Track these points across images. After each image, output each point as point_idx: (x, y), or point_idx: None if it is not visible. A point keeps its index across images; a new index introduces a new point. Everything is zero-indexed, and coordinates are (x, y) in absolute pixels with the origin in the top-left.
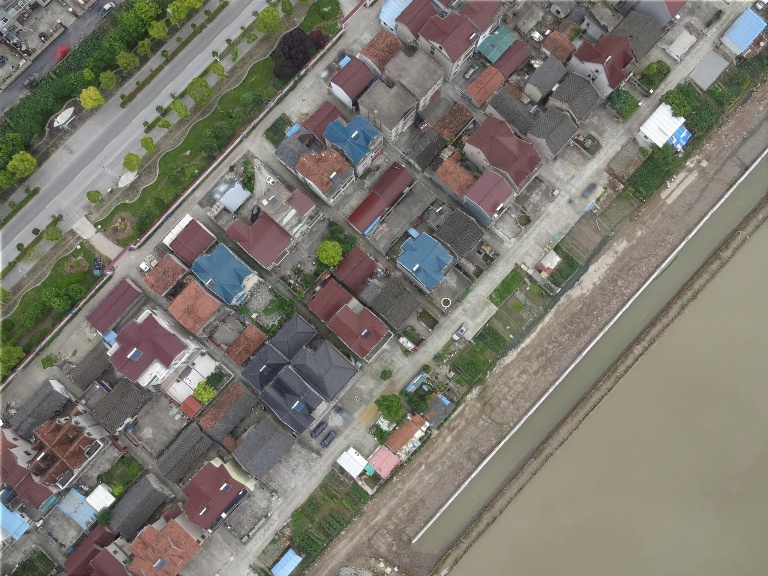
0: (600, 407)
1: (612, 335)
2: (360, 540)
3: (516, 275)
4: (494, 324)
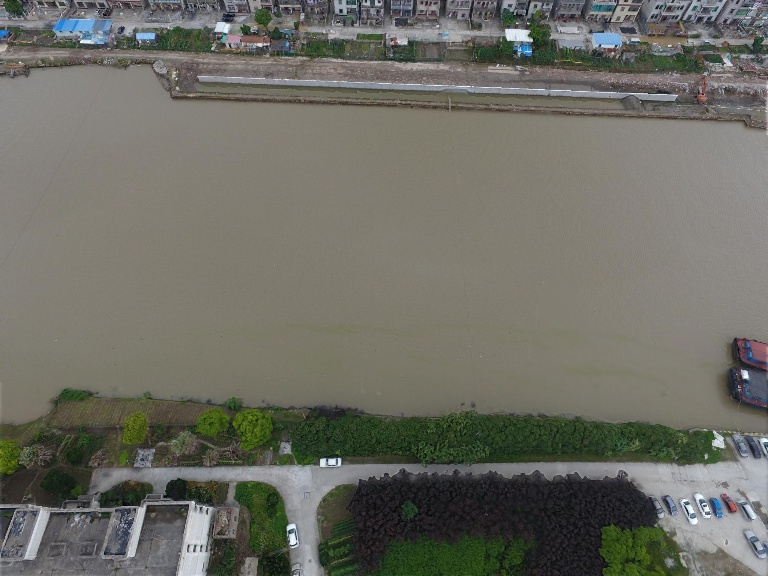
0: (348, 107)
1: (394, 93)
2: (182, 59)
3: (380, 36)
4: (347, 45)
